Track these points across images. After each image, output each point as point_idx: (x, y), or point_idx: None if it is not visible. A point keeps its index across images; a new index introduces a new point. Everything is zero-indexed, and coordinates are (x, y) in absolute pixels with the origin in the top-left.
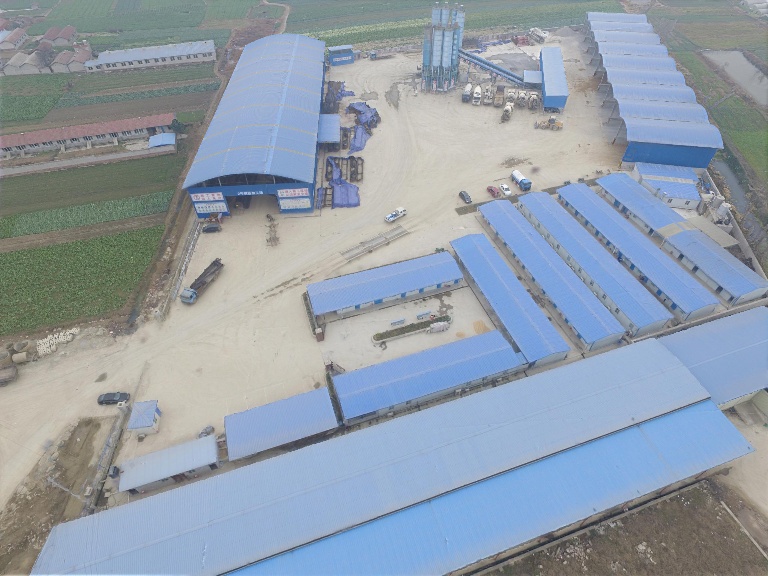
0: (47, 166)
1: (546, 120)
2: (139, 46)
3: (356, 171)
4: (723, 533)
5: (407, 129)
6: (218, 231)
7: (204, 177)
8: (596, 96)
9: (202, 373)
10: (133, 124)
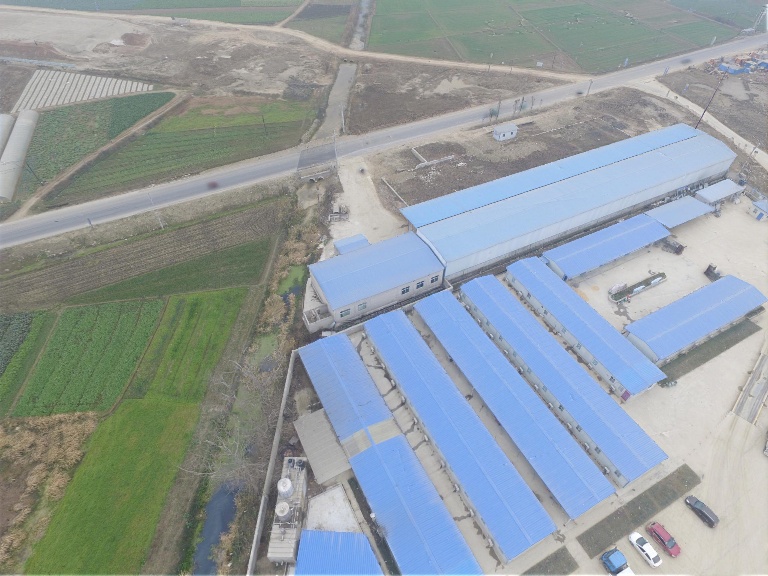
0: None
1: None
2: None
3: None
4: (418, 200)
5: None
6: None
7: None
8: None
9: (765, 243)
10: None
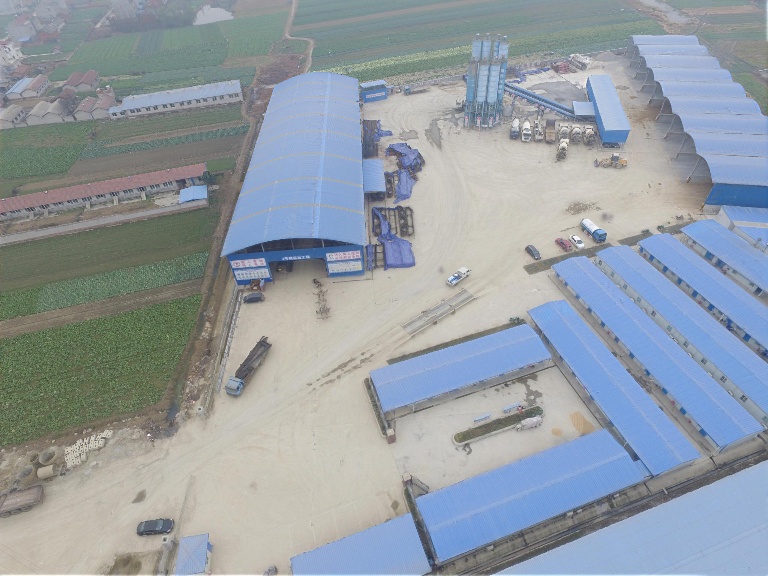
0: (72, 227)
1: (607, 157)
2: (163, 88)
3: (406, 224)
4: None
5: (455, 172)
6: (261, 301)
7: (245, 243)
8: (656, 127)
9: (257, 489)
10: (162, 177)
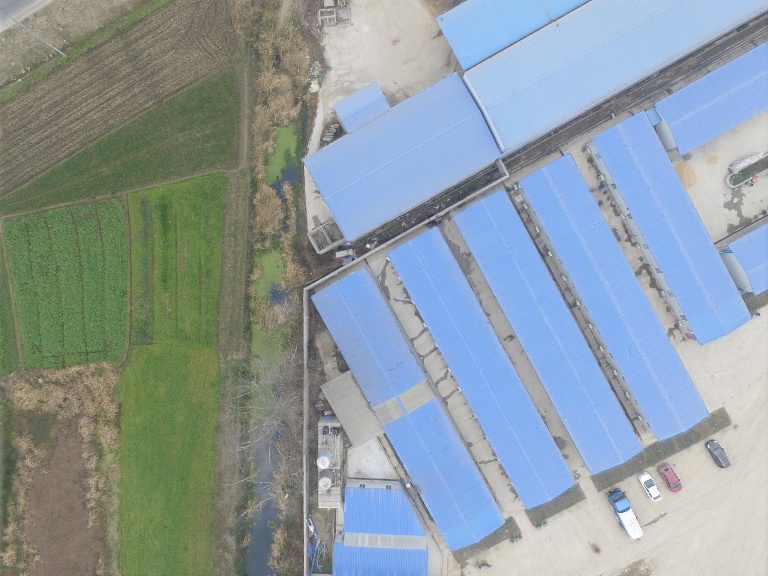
0: None
1: None
2: None
3: None
4: None
5: None
6: None
7: None
8: None
9: None
10: None
